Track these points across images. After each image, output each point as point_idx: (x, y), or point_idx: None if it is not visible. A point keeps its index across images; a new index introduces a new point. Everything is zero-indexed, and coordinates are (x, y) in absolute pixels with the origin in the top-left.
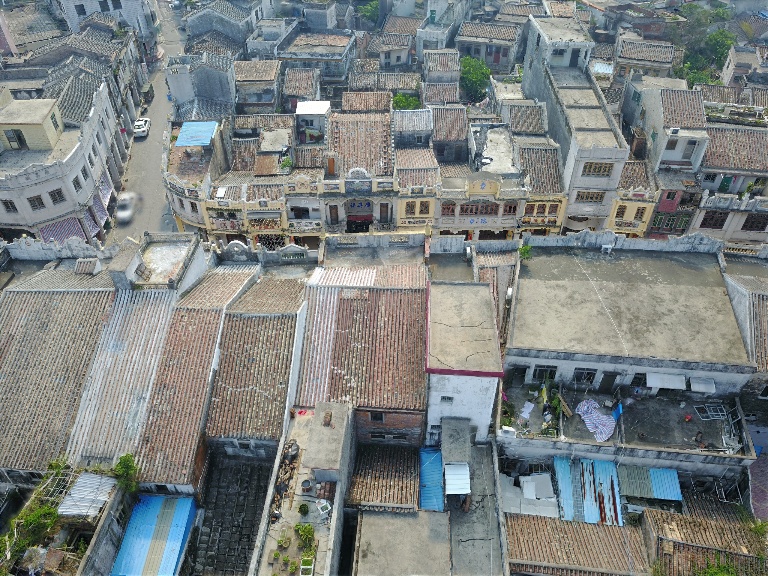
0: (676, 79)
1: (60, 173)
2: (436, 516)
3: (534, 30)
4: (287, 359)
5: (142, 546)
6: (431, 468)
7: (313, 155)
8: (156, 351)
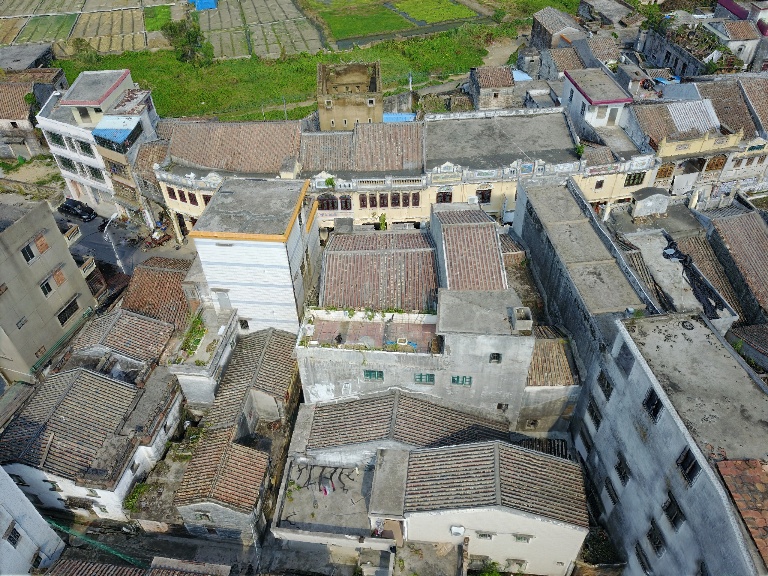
0: (453, 331)
1: None
2: None
3: None
4: None
5: None
6: None
7: None
8: None
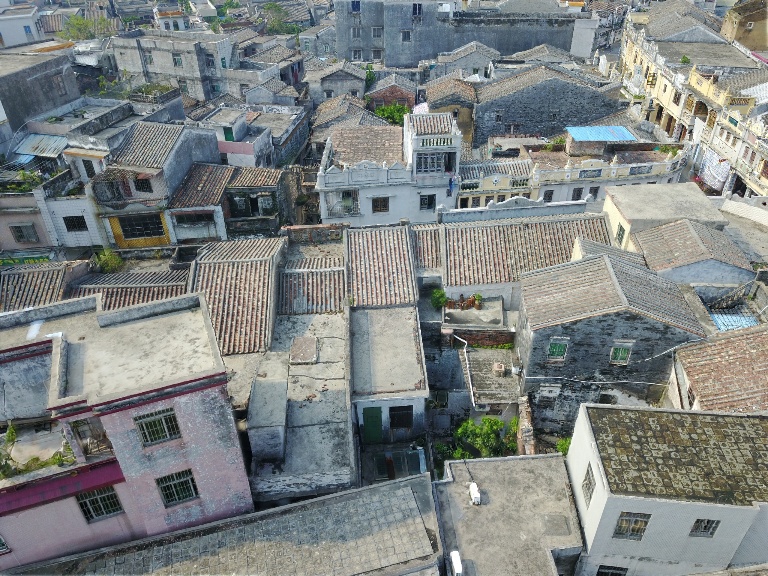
0: None
1: None
2: None
3: (401, 6)
4: None
5: None
6: None
7: None
8: None
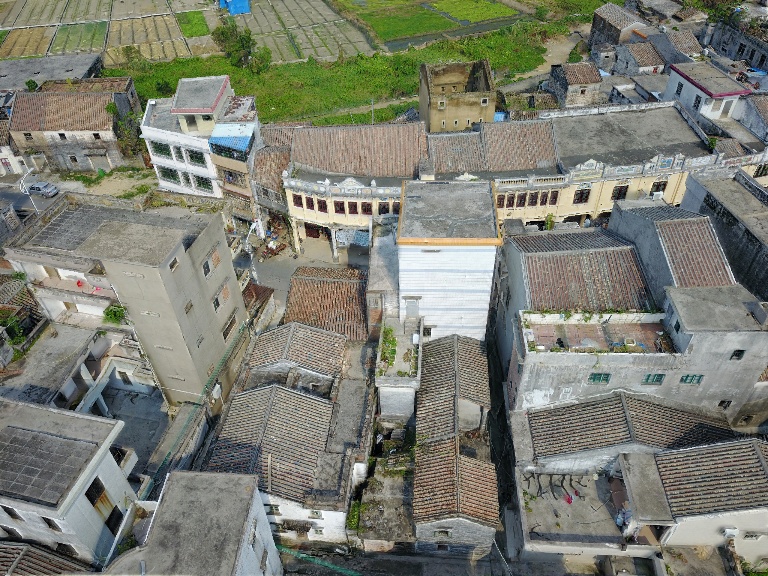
0: (701, 329)
1: None
2: None
3: None
4: None
5: None
6: None
7: None
8: None
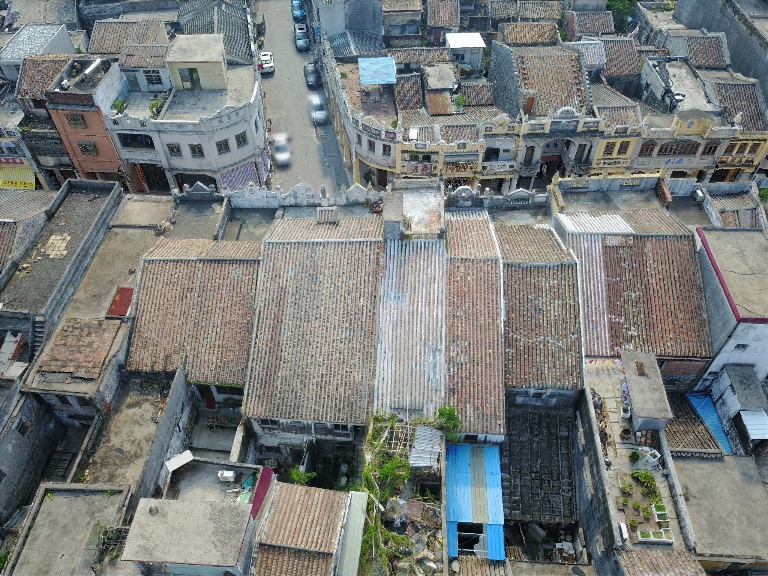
0: None
1: (248, 115)
2: (742, 460)
3: None
4: (574, 309)
5: (464, 493)
6: (704, 413)
7: (477, 92)
8: (441, 302)
